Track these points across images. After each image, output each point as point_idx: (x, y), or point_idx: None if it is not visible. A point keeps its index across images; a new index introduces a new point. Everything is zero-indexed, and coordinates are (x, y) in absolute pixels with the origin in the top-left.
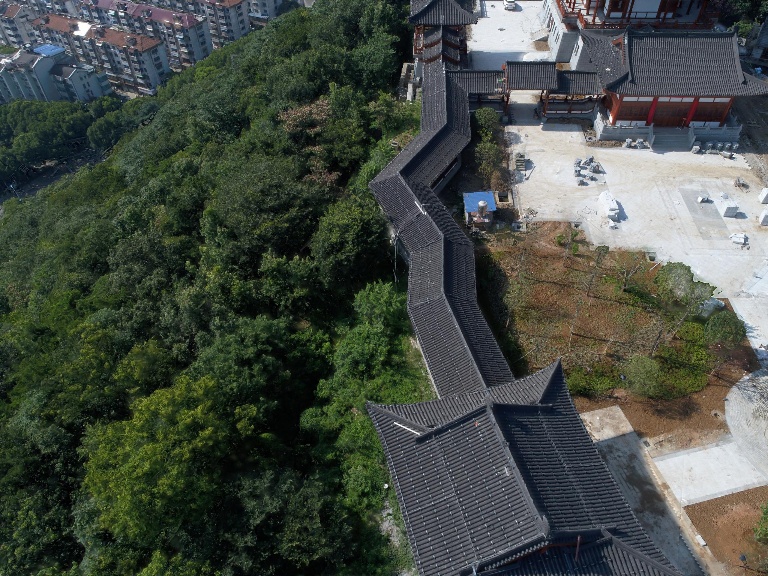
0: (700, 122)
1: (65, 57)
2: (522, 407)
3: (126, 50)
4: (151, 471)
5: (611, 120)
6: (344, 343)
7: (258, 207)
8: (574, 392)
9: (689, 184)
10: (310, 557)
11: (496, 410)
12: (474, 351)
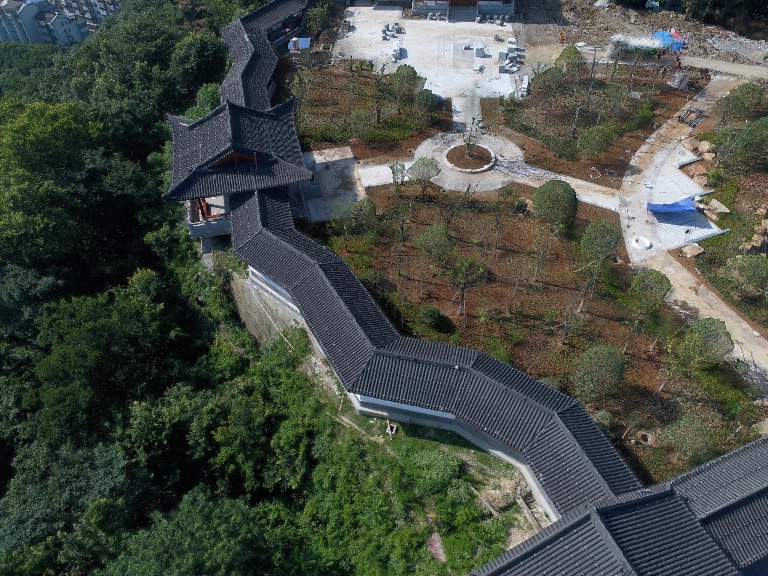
0: (486, 2)
1: (48, 5)
2: (253, 111)
3: (104, 0)
4: (26, 131)
5: (422, 1)
6: (181, 115)
7: (136, 38)
8: (323, 139)
9: (462, 40)
10: (122, 192)
11: (234, 108)
12: (249, 102)
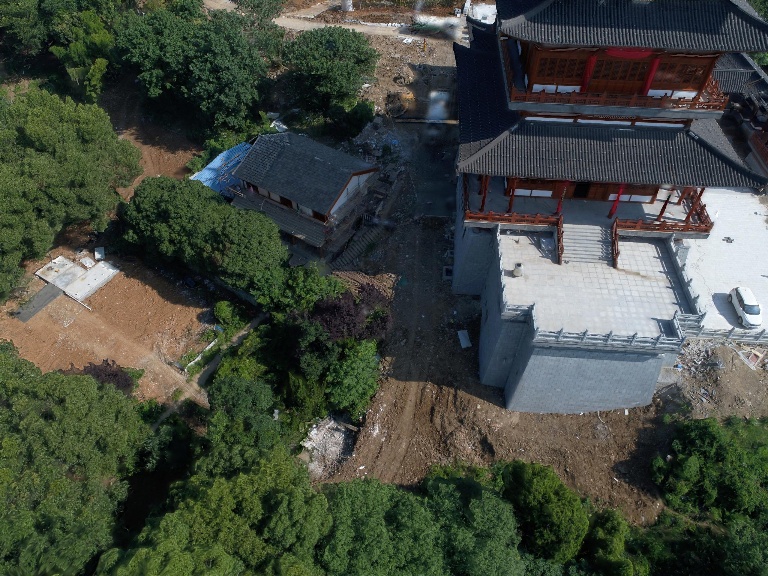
0: None
1: None
2: None
3: None
4: None
5: None
6: None
7: None
8: None
9: None
10: None
11: None
12: None
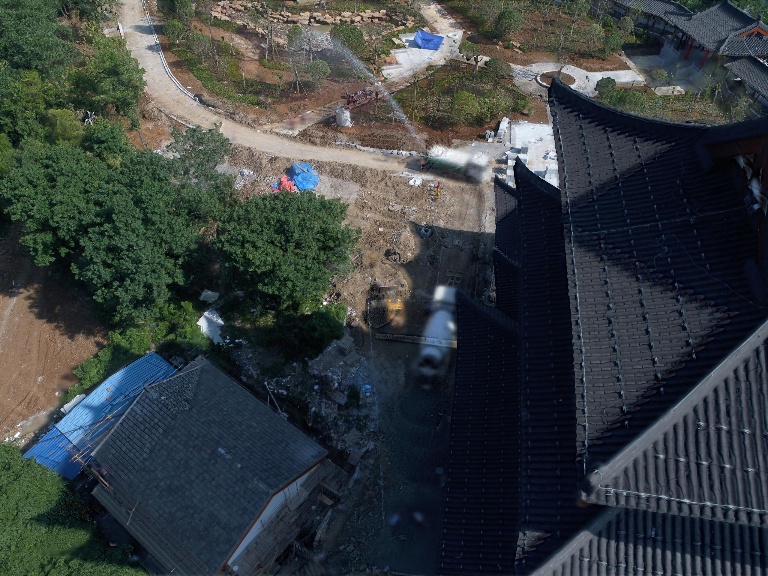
0: None
1: None
2: None
3: None
4: None
5: None
6: None
7: None
8: None
9: None
10: None
11: None
12: (762, 71)
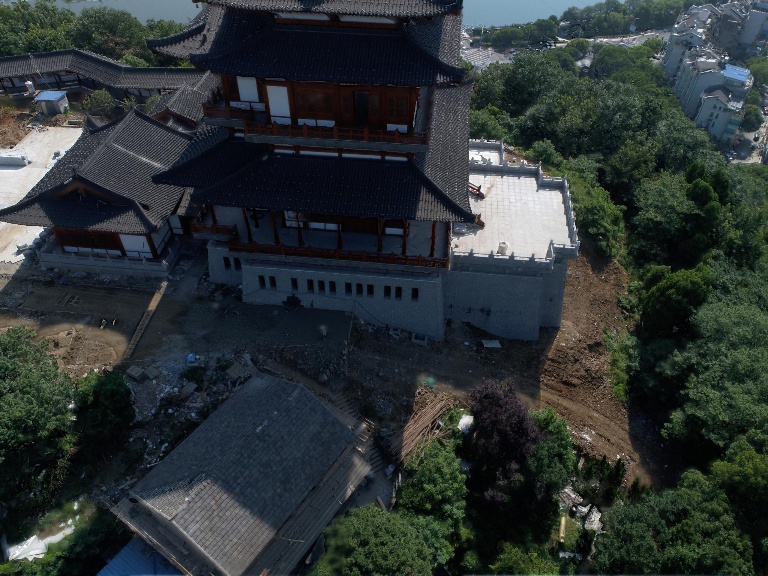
0: None
1: (738, 86)
2: None
3: None
4: None
5: None
6: None
7: None
8: None
9: None
10: None
11: None
12: None
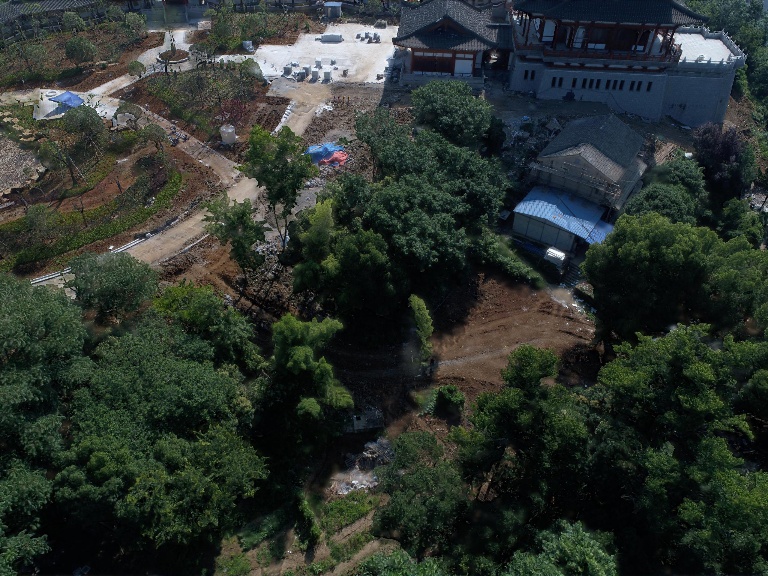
0: None
1: None
2: None
3: None
4: None
5: None
6: None
7: None
8: None
9: (351, 62)
10: None
11: None
12: None
